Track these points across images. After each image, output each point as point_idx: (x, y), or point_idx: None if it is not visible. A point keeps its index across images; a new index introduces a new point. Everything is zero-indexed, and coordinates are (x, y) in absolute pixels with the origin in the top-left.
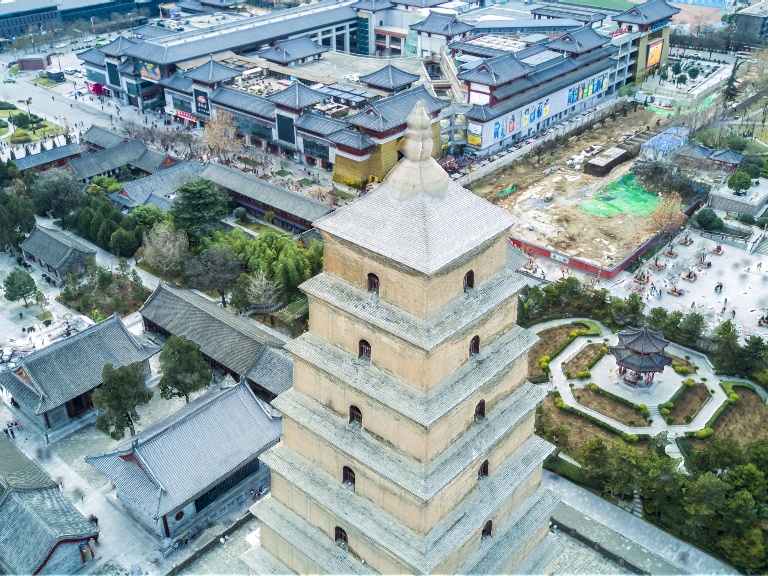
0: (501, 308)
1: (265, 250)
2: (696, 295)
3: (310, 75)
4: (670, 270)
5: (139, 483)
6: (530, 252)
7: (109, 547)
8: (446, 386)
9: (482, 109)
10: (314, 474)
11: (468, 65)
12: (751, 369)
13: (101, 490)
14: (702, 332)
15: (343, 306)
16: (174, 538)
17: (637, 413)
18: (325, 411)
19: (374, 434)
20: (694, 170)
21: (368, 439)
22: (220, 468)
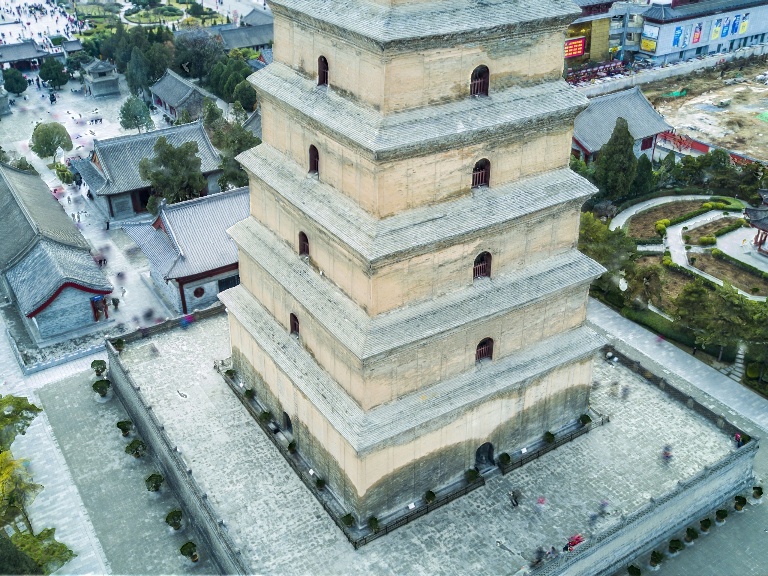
0: None
1: None
2: None
3: None
4: None
5: (163, 249)
6: None
7: (126, 314)
8: (423, 11)
9: (662, 8)
10: (283, 167)
11: None
12: None
13: (139, 270)
14: None
15: None
16: None
17: (766, 283)
18: (297, 77)
19: (338, 89)
20: None
21: (332, 97)
22: None
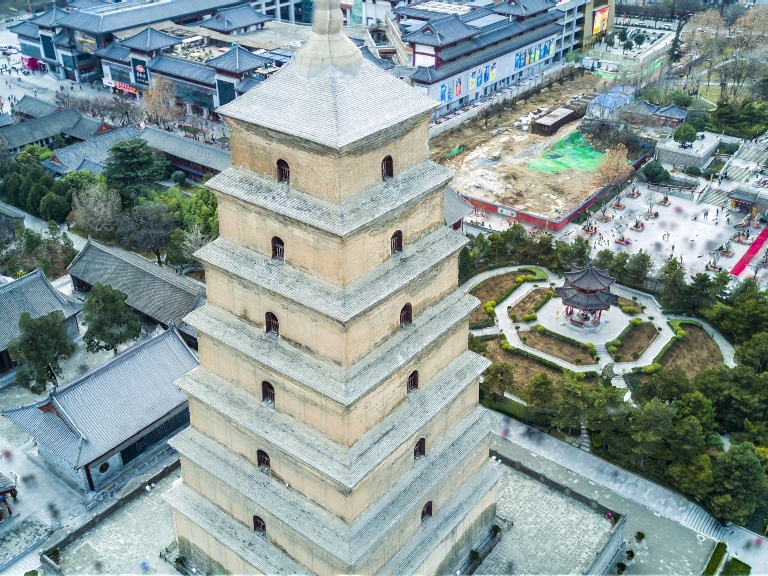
0: (425, 202)
1: (201, 206)
2: (644, 244)
3: (252, 41)
4: (617, 220)
5: (59, 434)
6: (476, 206)
7: (28, 504)
8: (366, 282)
9: (427, 71)
10: (232, 394)
11: (413, 28)
12: (698, 307)
13: (22, 448)
14: (649, 272)
15: (252, 199)
16: (99, 491)
17: (584, 352)
18: (240, 323)
19: (292, 341)
20: (640, 127)
21: (285, 347)
22: (147, 416)
